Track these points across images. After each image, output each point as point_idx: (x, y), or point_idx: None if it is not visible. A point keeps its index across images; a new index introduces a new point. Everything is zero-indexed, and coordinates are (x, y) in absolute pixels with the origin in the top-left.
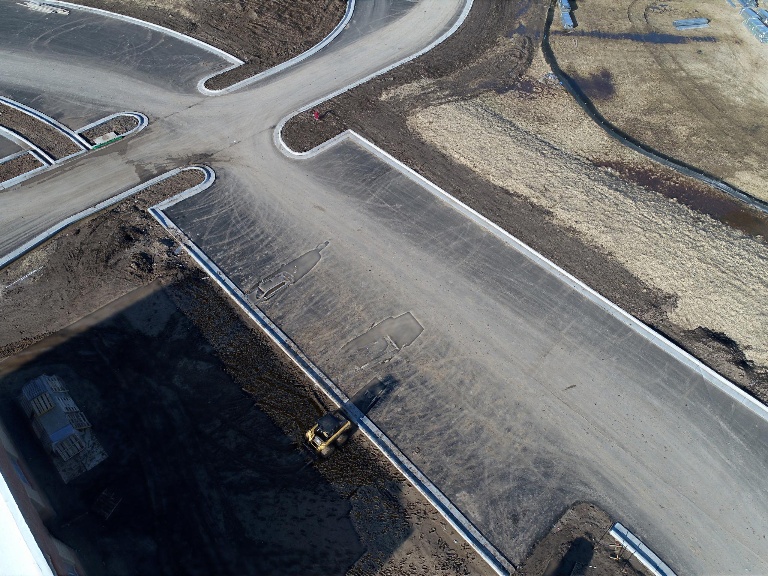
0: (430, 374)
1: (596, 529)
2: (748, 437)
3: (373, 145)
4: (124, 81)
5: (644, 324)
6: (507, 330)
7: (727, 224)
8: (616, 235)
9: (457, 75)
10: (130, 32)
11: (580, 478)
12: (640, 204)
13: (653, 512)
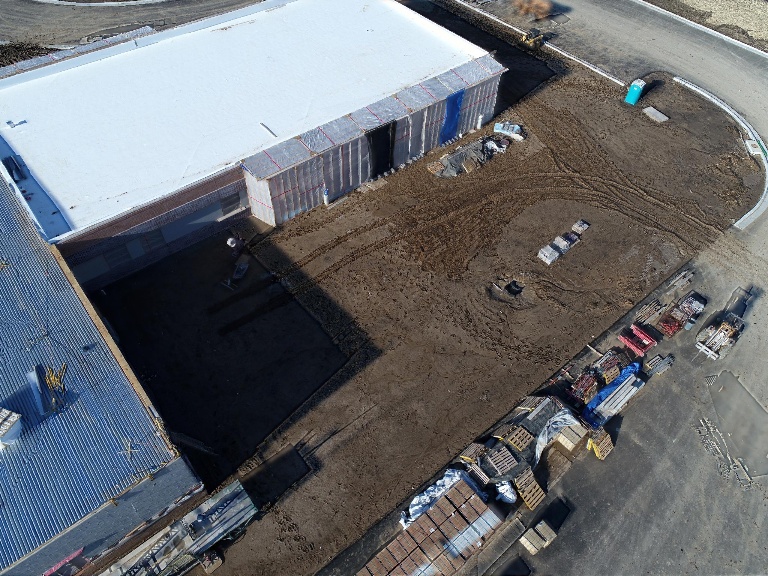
0: (577, 33)
1: (666, 78)
2: (746, 58)
3: None
4: None
5: (693, 22)
6: (617, 21)
7: None
8: None
9: None
10: None
11: (658, 65)
12: None
13: (695, 75)
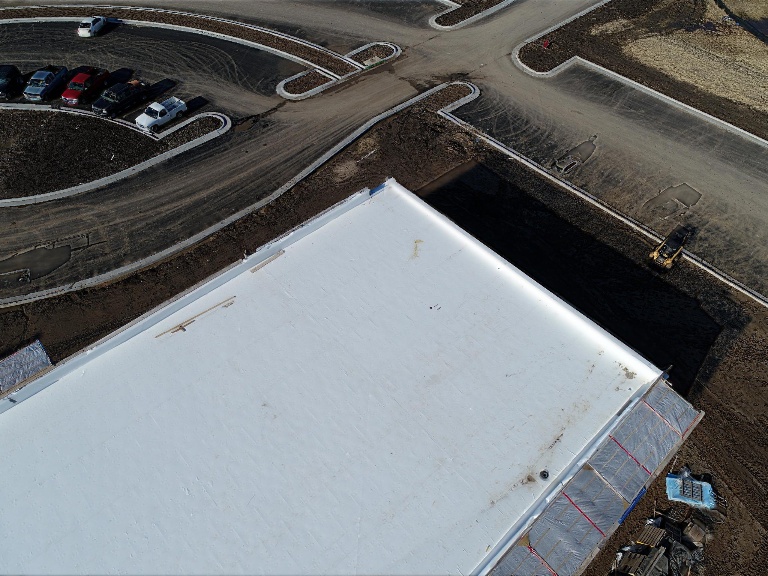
0: (720, 224)
1: None
2: None
3: (602, 67)
4: (365, 19)
5: None
6: None
7: None
8: None
9: (646, 17)
10: None
11: None
12: None
13: None
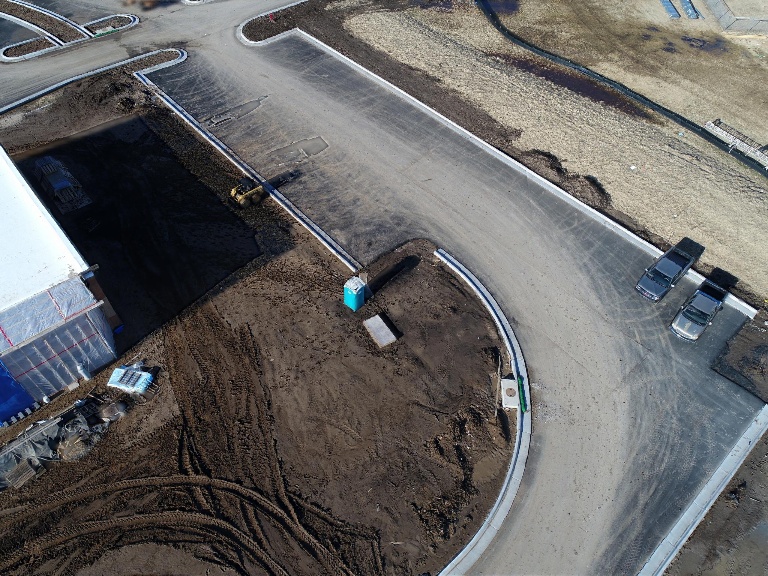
0: (328, 170)
1: (425, 252)
2: (548, 209)
3: (313, 38)
4: None
5: (492, 146)
6: (390, 148)
7: (579, 94)
8: (486, 94)
9: None
10: None
11: (421, 226)
12: (512, 77)
13: (467, 244)
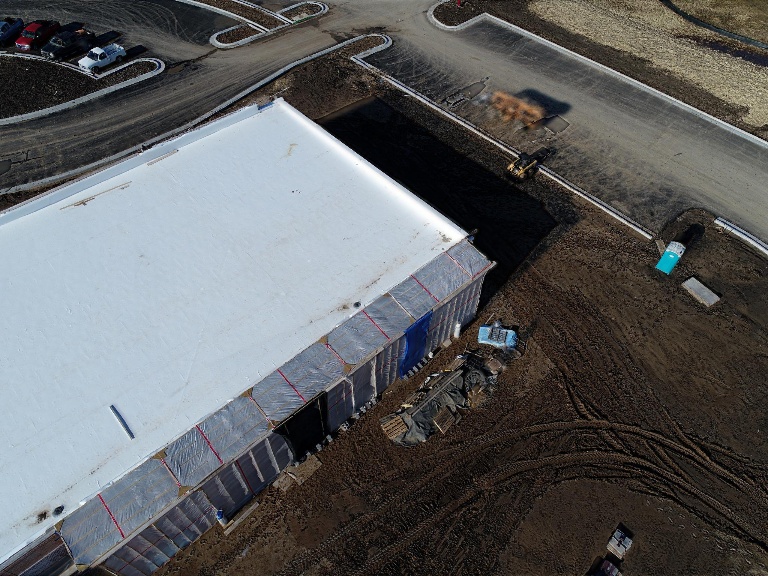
0: (580, 146)
1: (705, 220)
2: None
3: (506, 22)
4: None
5: (726, 122)
6: (629, 125)
7: None
8: (701, 73)
9: None
10: None
11: (691, 197)
12: (716, 57)
13: (742, 213)
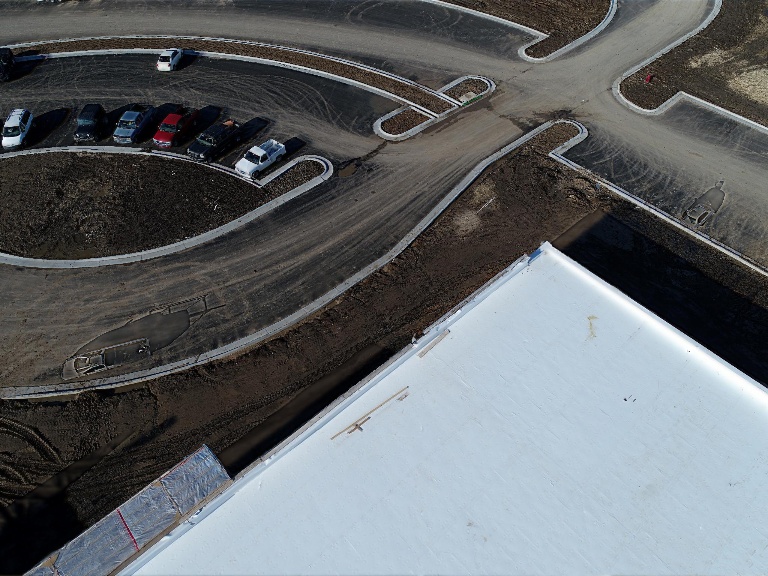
0: None
1: None
2: None
3: (711, 104)
4: (451, 50)
5: None
6: None
7: None
8: None
9: (743, 47)
10: (427, 9)
11: None
12: None
13: None
